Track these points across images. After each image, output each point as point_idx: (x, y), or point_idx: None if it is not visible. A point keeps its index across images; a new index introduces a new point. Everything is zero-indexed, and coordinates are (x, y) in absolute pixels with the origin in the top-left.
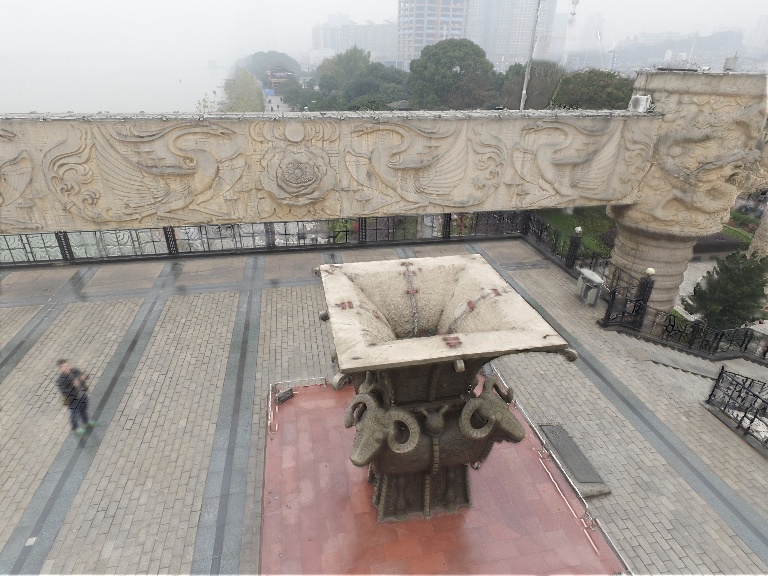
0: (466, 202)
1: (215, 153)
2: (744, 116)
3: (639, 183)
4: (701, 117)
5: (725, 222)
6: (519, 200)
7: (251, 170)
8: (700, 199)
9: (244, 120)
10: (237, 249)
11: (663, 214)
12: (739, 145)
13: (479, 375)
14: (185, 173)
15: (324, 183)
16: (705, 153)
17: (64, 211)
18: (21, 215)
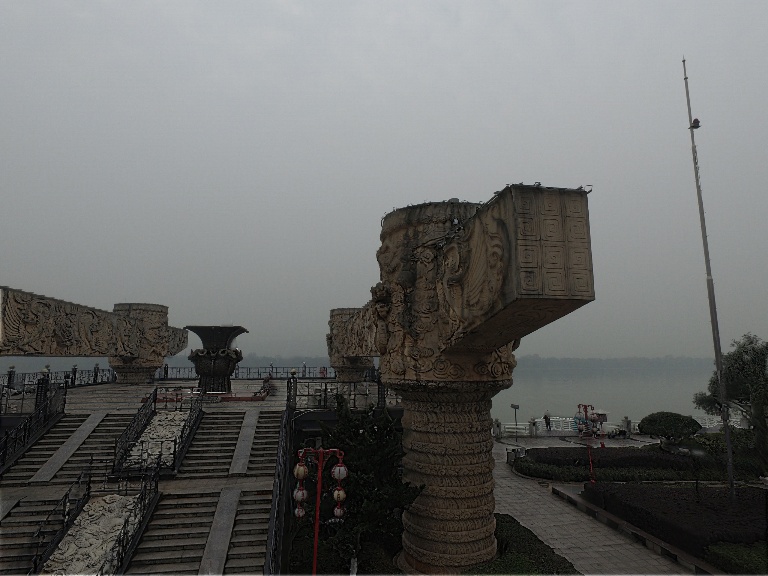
0: None
1: None
2: None
3: None
4: None
5: (393, 370)
6: None
7: None
8: None
9: None
10: None
11: None
12: (386, 282)
13: None
14: None
15: None
16: None
17: None
18: None
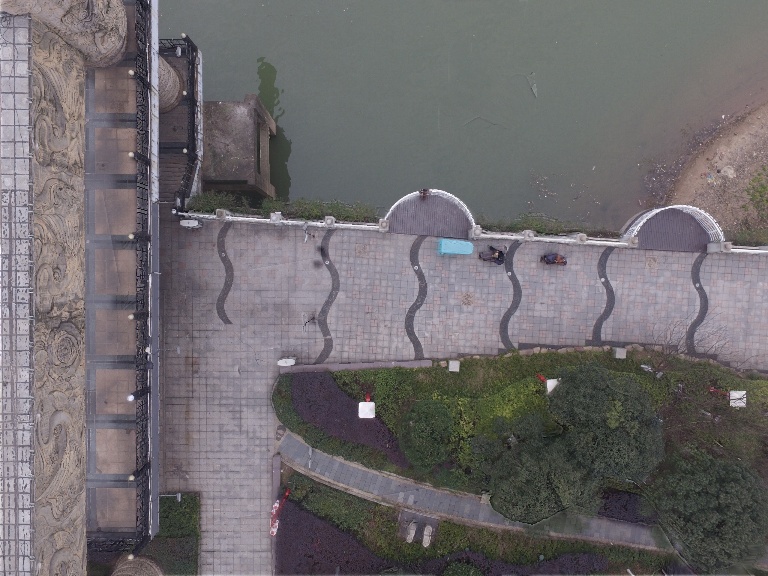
0: None
1: None
2: None
3: None
4: None
5: None
6: None
7: None
8: None
9: None
10: None
11: None
12: None
13: None
14: None
15: None
16: None
17: None
18: None
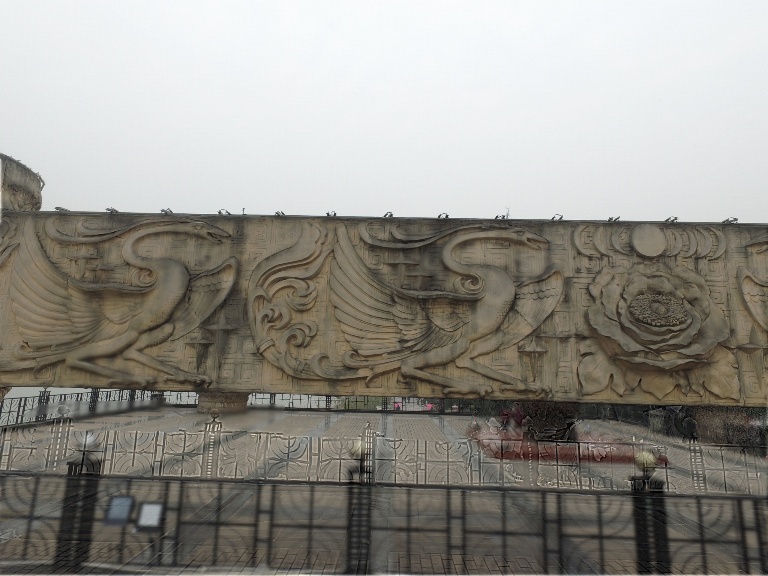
0: None
1: (512, 272)
2: None
3: None
4: None
5: None
6: None
7: (569, 303)
8: None
9: (564, 222)
10: (472, 486)
11: None
12: None
13: None
14: (464, 298)
15: (708, 330)
16: None
17: (253, 356)
18: (187, 358)
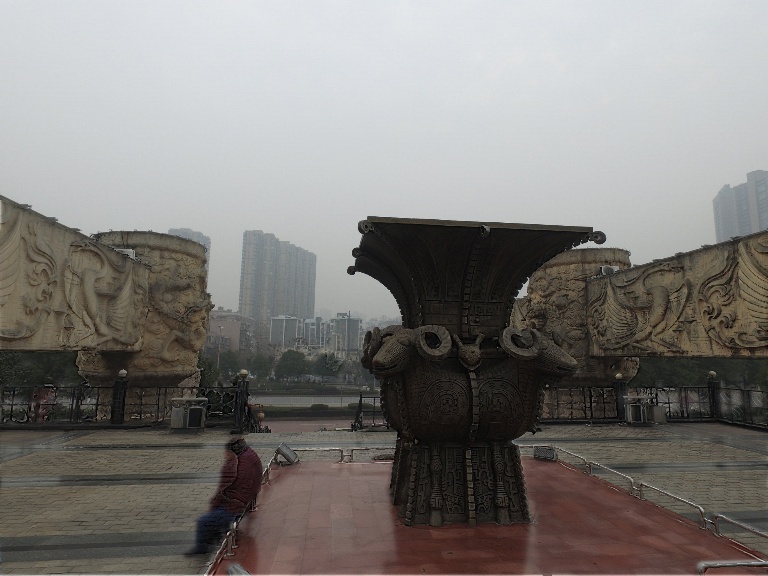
0: (16, 332)
1: None
2: (203, 273)
3: (142, 329)
4: (181, 270)
5: None
6: (66, 337)
7: None
8: (194, 337)
9: None
10: None
11: (169, 355)
12: None
13: (288, 466)
14: None
15: None
16: (187, 299)
17: None
18: None
